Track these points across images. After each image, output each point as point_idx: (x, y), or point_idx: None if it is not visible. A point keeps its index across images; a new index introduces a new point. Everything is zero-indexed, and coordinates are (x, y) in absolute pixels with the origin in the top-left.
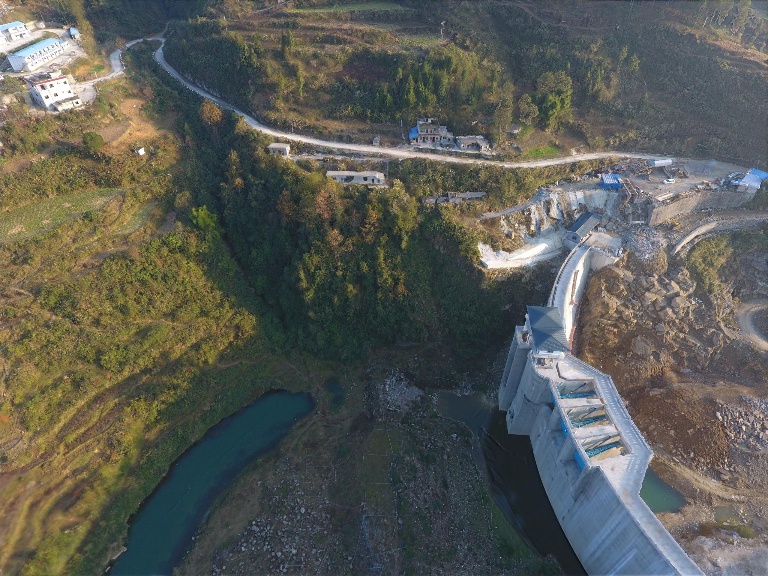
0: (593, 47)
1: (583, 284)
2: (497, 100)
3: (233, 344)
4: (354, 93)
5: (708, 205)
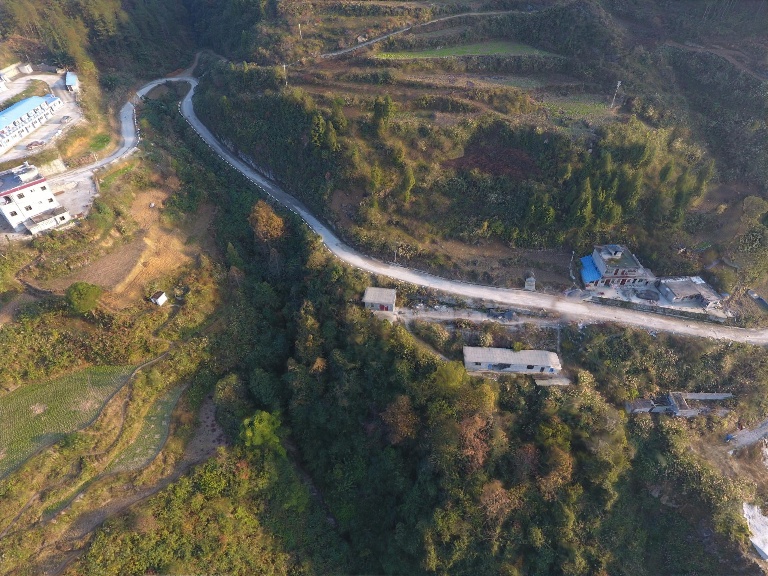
0: None
1: None
2: (702, 206)
3: None
4: (486, 195)
5: None
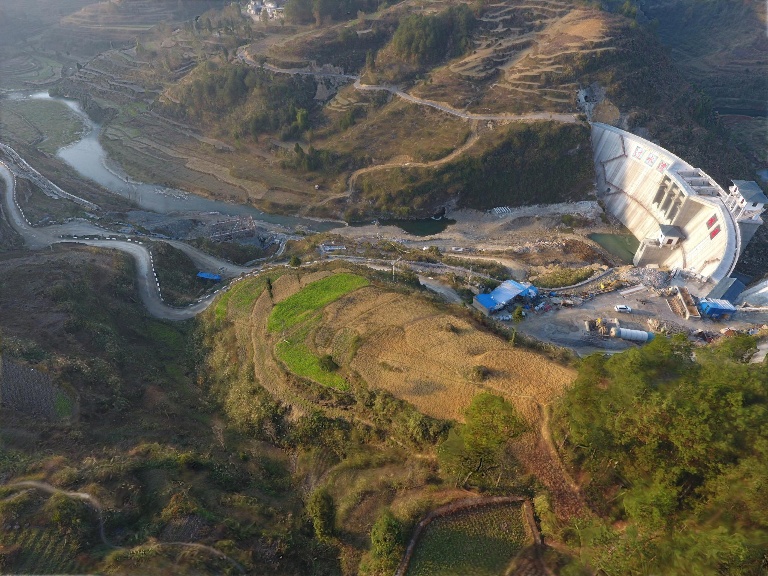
0: None
1: None
2: None
3: None
4: None
5: None
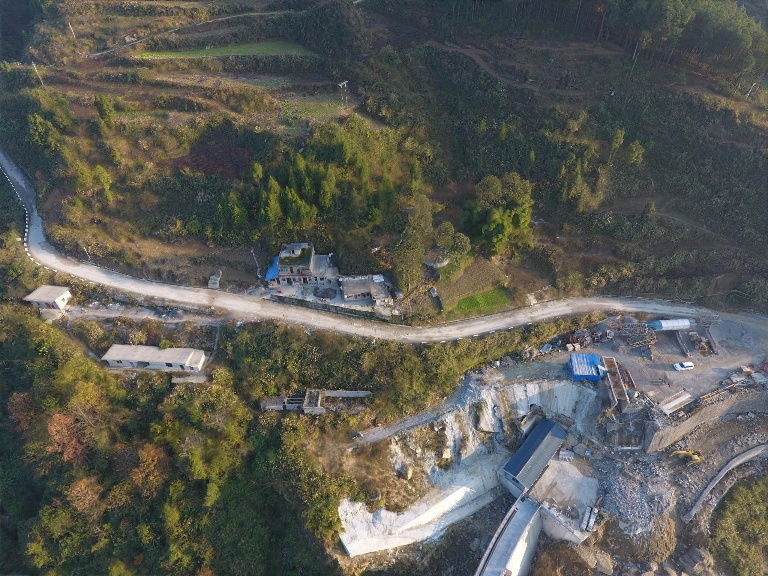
0: (572, 125)
1: (528, 560)
2: None
3: None
4: (197, 194)
5: (748, 408)
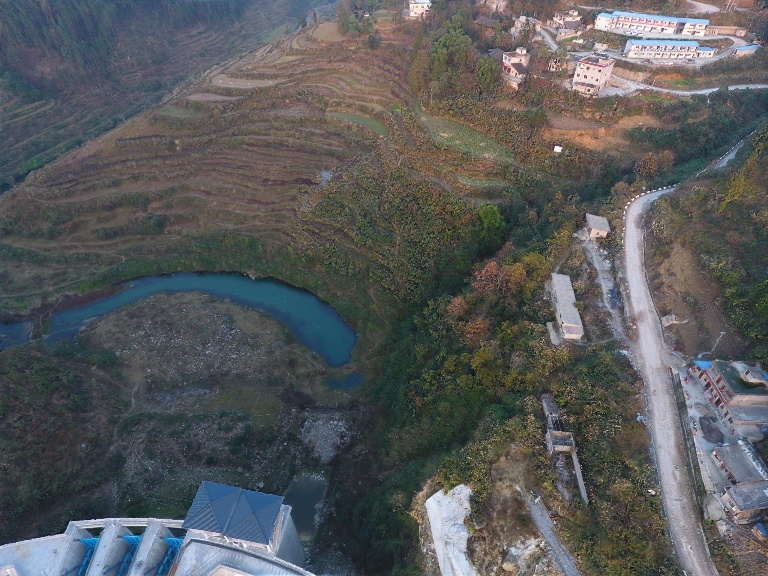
0: None
1: None
2: None
3: (387, 291)
4: None
5: None
